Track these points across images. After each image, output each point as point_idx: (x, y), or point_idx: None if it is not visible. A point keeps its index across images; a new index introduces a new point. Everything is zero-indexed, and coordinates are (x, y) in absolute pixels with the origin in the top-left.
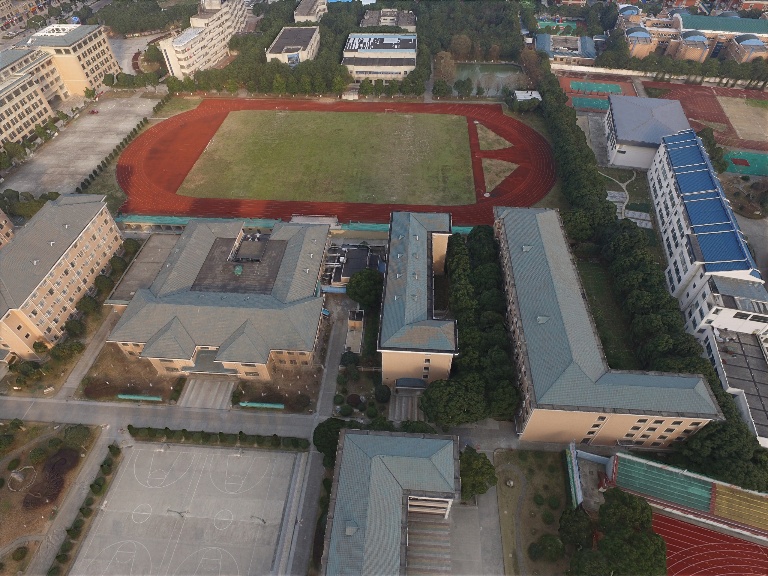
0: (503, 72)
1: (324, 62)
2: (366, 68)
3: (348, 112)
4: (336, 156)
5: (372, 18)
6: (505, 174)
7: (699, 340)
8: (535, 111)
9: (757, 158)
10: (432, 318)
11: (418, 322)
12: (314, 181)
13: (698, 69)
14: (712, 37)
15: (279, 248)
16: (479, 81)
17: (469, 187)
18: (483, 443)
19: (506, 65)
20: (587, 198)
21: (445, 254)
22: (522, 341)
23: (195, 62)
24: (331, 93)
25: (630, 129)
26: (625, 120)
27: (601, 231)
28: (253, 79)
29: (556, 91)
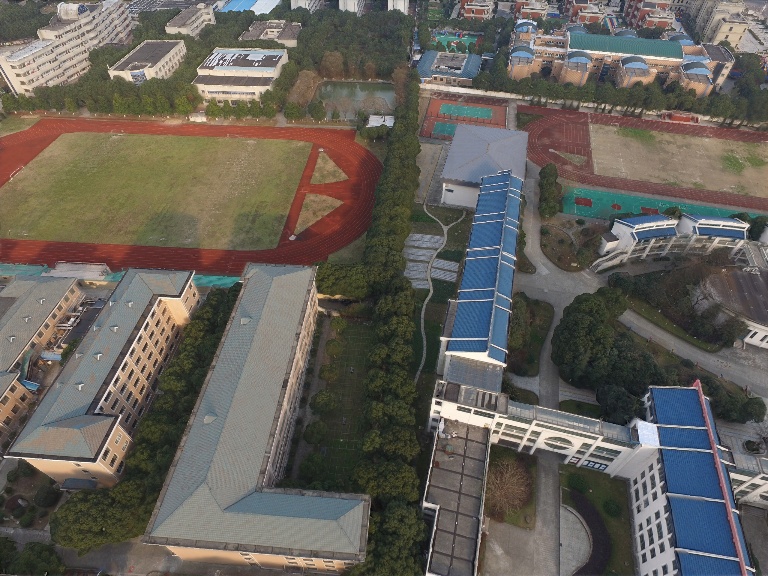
0: (384, 91)
1: (175, 80)
2: (218, 88)
3: (189, 136)
4: (150, 188)
5: (256, 30)
6: (323, 213)
7: (435, 430)
8: (387, 138)
9: (603, 197)
10: (93, 412)
11: (65, 420)
12: (111, 218)
13: (574, 94)
14: (600, 58)
15: (3, 307)
16: (334, 104)
17: (277, 228)
18: (139, 563)
19: (384, 84)
20: (373, 250)
21: (189, 317)
22: (181, 445)
23: (41, 77)
24: (179, 114)
25: (457, 166)
26: (458, 155)
27: (378, 289)
28: (95, 98)
29: (407, 118)
